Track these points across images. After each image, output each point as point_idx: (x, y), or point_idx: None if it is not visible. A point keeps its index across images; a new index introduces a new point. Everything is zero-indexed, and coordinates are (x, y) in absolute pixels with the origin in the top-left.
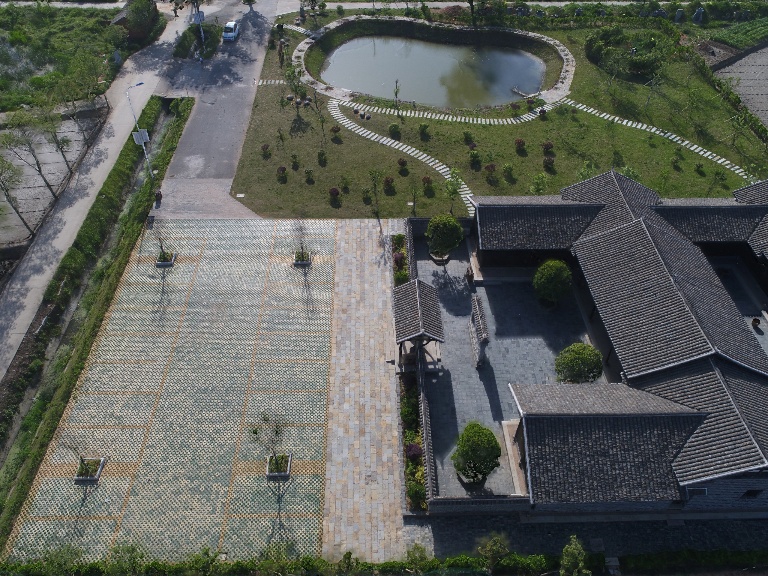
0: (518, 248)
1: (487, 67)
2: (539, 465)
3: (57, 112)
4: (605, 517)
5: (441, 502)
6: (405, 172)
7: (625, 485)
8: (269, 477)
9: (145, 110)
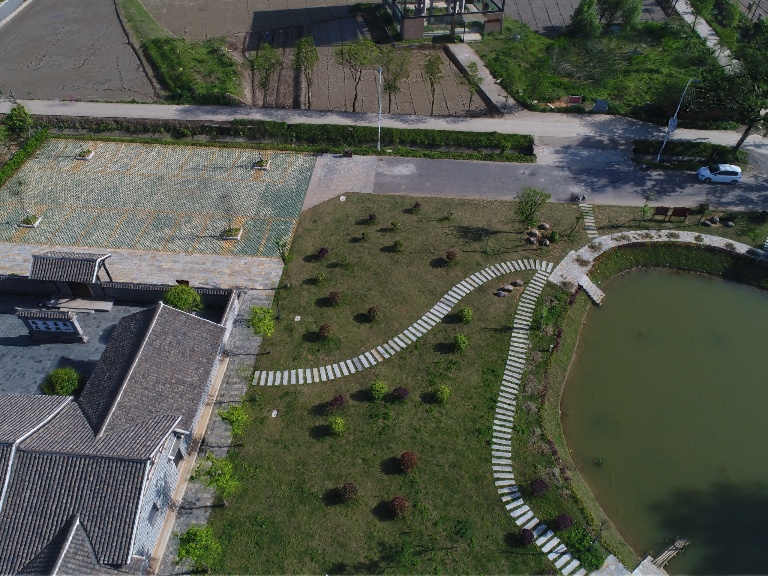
0: (105, 350)
1: None
2: None
3: (493, 95)
4: None
5: None
6: (363, 319)
7: None
8: None
9: (497, 134)
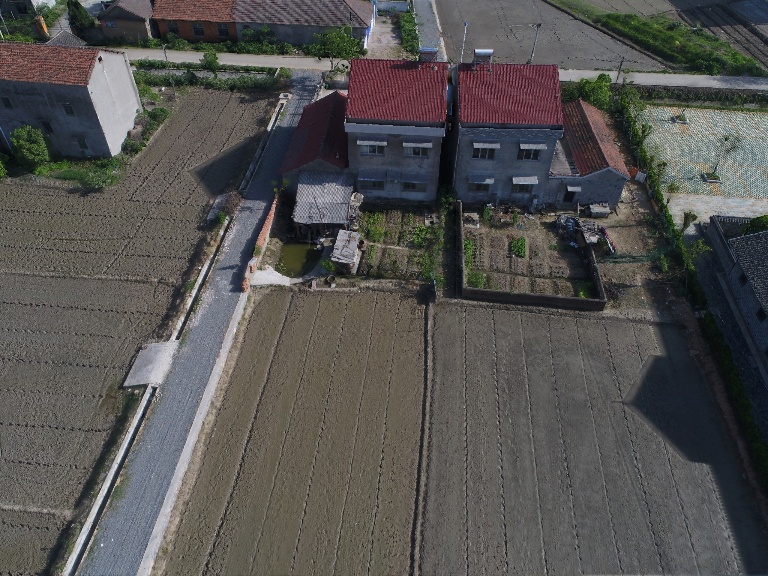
0: None
1: None
2: (760, 239)
3: None
4: (739, 317)
5: (714, 221)
6: None
7: (765, 284)
8: (703, 175)
9: None
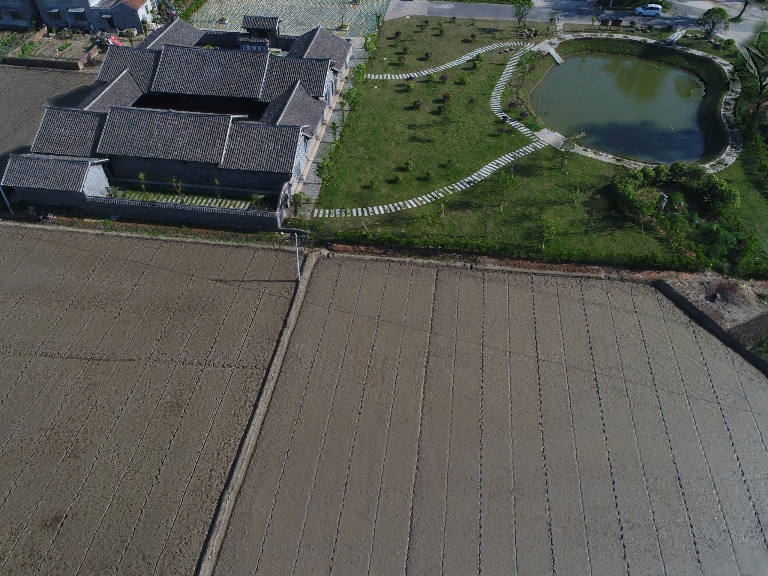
0: None
1: (641, 131)
2: None
3: None
4: None
5: None
6: (422, 59)
7: None
8: None
9: None
